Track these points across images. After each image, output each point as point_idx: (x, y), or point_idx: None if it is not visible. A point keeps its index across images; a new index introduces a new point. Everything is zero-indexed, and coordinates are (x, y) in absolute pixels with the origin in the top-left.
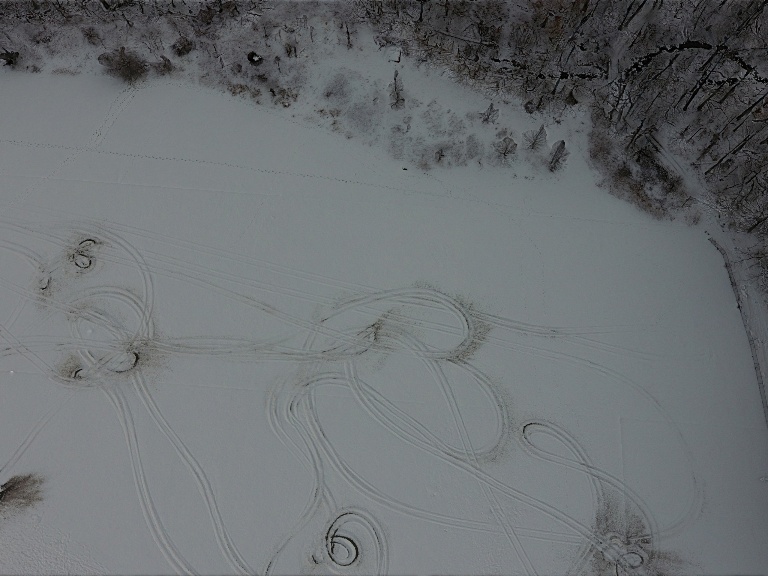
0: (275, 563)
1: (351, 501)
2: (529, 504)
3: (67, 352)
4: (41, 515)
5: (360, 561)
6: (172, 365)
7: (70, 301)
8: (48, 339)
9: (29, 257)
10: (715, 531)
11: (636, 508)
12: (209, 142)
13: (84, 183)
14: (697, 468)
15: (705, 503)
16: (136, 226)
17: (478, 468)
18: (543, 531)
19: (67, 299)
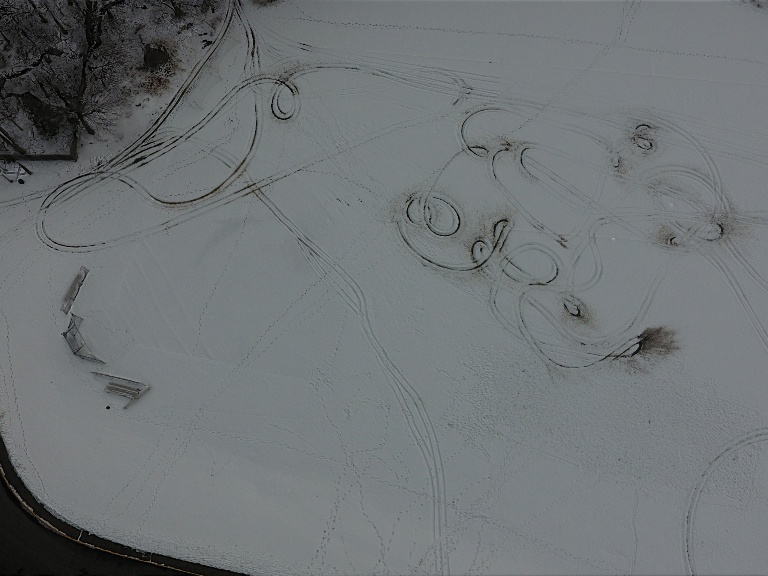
0: None
1: None
2: None
3: (657, 222)
4: (683, 362)
5: None
6: (756, 235)
7: (645, 178)
8: (636, 211)
9: (594, 139)
10: None
11: None
12: (724, 40)
13: (622, 75)
14: None
15: None
16: (683, 113)
17: None
18: None
19: (642, 176)
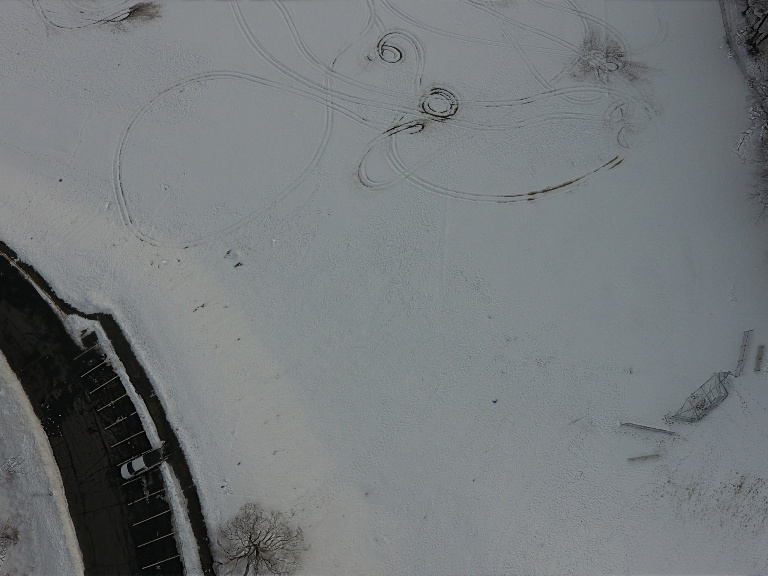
0: (339, 59)
1: (396, 25)
2: (532, 32)
3: None
4: (161, 25)
5: (403, 60)
6: None
7: None
8: None
9: None
10: (674, 51)
11: (614, 36)
12: None
13: None
14: (662, 14)
15: (667, 34)
16: None
17: (493, 10)
18: (543, 48)
19: None
